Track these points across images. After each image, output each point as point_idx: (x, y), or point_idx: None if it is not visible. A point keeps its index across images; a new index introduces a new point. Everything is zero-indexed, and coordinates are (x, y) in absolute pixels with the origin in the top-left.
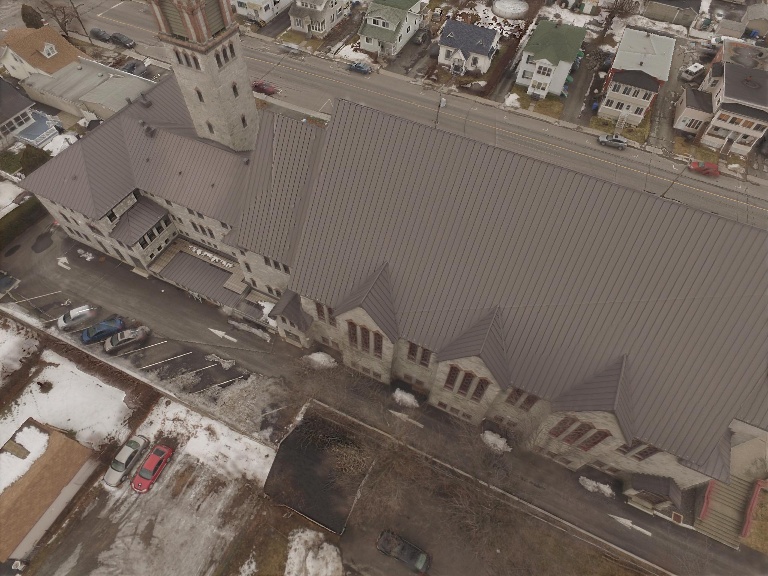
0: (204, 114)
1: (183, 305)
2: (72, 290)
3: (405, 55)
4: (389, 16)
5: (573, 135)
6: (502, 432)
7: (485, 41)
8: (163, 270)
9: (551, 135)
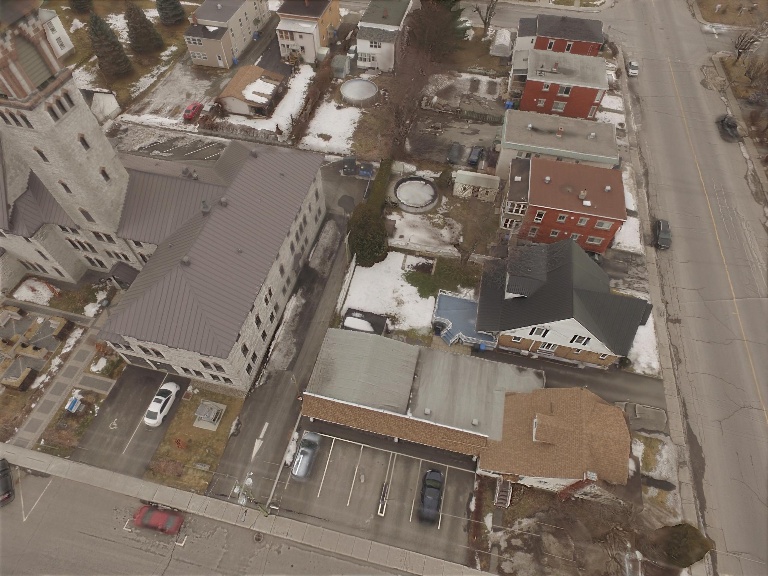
0: None
1: None
2: None
3: None
4: None
5: None
6: None
7: None
8: None
9: None
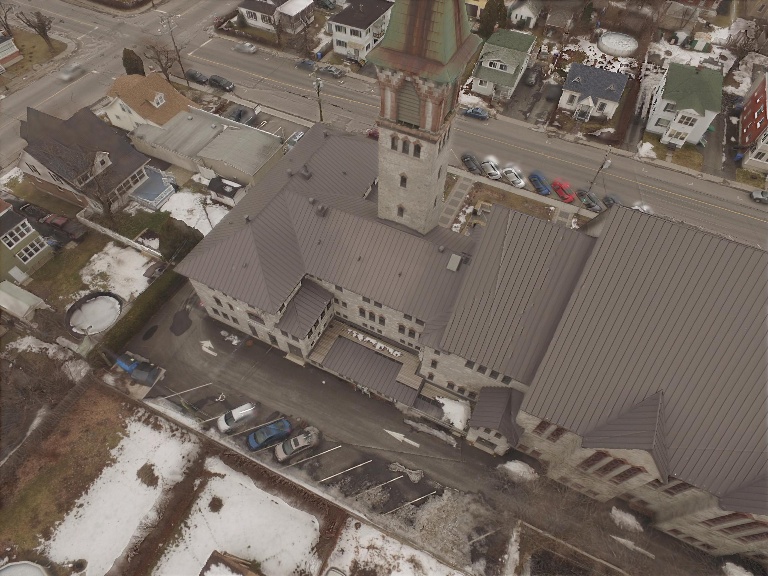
0: (399, 198)
1: (350, 400)
2: (224, 382)
3: (519, 98)
4: (508, 59)
5: (721, 190)
6: (746, 564)
7: (615, 86)
8: (325, 359)
9: (698, 190)
